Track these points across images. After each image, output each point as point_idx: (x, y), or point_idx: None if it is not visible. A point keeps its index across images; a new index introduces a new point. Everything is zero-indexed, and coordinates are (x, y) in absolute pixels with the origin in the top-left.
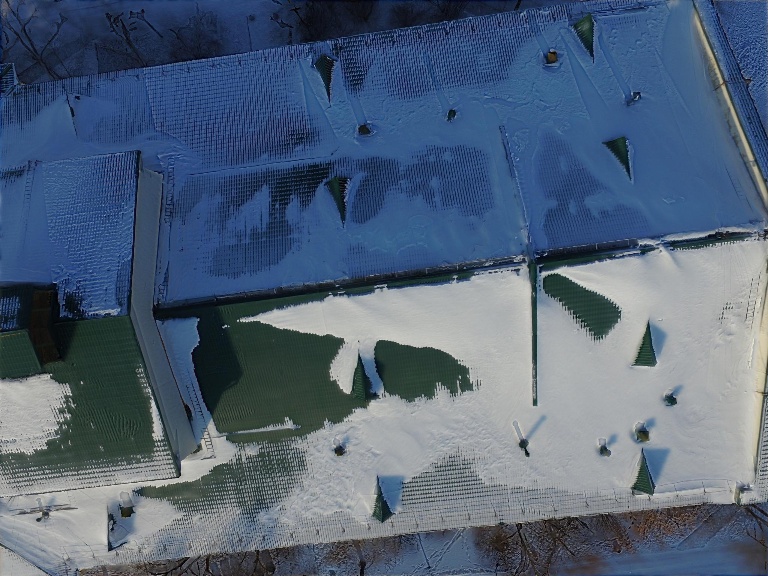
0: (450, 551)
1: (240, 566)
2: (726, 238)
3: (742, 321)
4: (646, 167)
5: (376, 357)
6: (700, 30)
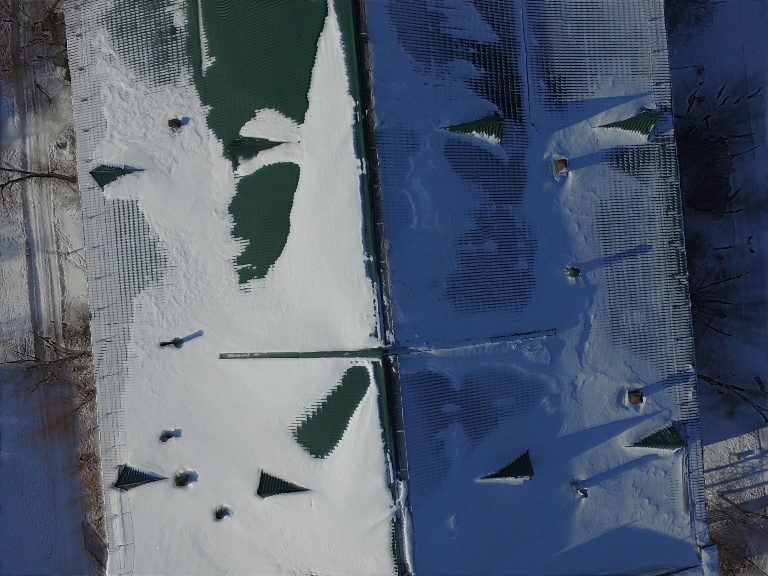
0: None
1: None
2: None
3: None
4: (496, 498)
5: (281, 164)
6: (658, 573)
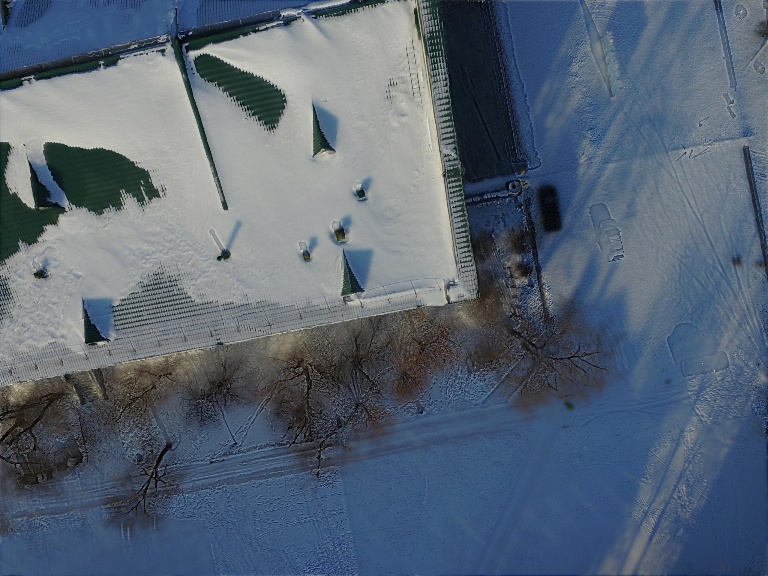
0: (254, 425)
1: (47, 457)
2: (366, 1)
3: (411, 98)
4: None
5: (48, 163)
6: None
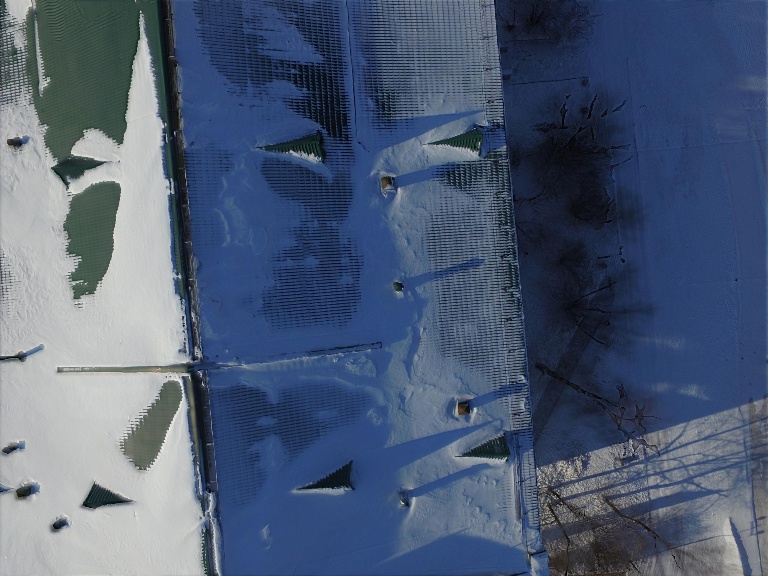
0: None
1: None
2: None
3: None
4: (315, 508)
5: (105, 183)
6: None
